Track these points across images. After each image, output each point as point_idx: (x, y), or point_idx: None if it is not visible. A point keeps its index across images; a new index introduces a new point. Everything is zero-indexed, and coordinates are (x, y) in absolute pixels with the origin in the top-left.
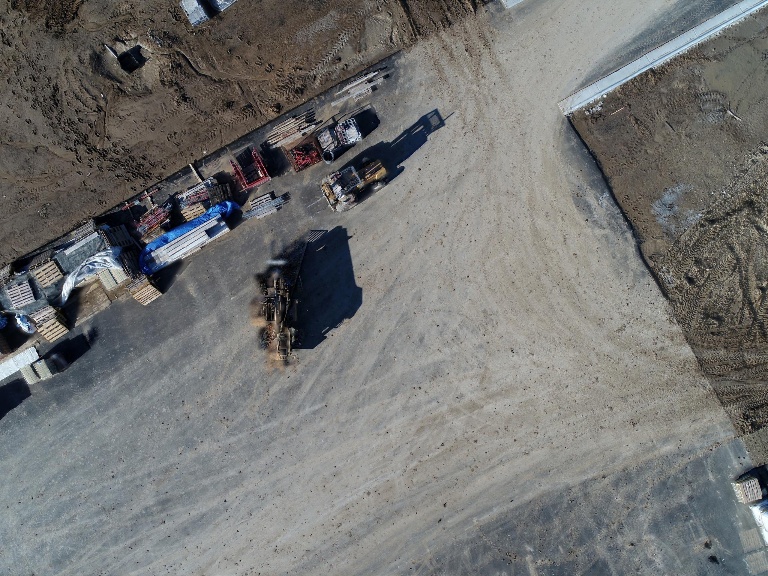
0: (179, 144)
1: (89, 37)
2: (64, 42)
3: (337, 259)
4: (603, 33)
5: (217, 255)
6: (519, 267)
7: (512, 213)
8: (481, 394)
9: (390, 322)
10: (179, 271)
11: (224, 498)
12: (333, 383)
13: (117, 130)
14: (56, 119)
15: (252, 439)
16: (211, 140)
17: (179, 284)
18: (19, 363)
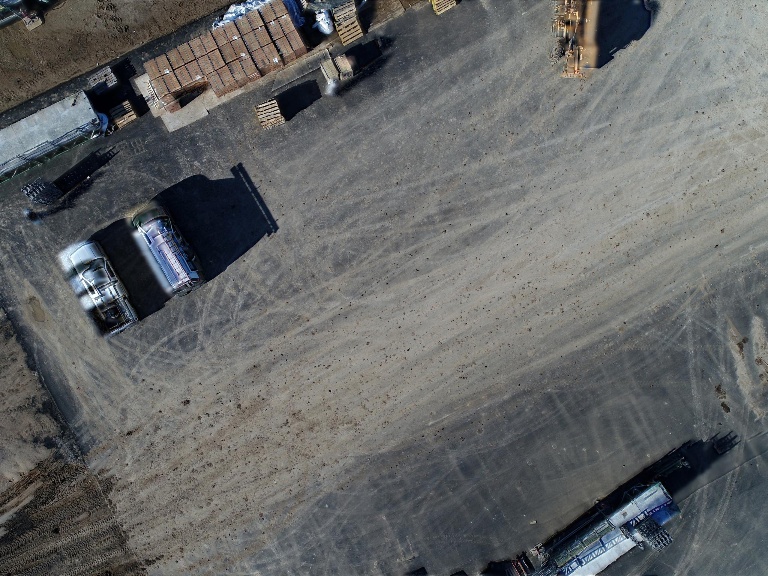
0: None
1: None
2: None
3: None
4: None
5: None
6: None
7: None
8: (763, 122)
9: (677, 46)
10: None
11: (505, 211)
12: (618, 103)
13: None
14: None
15: (536, 154)
16: None
17: None
18: (311, 65)
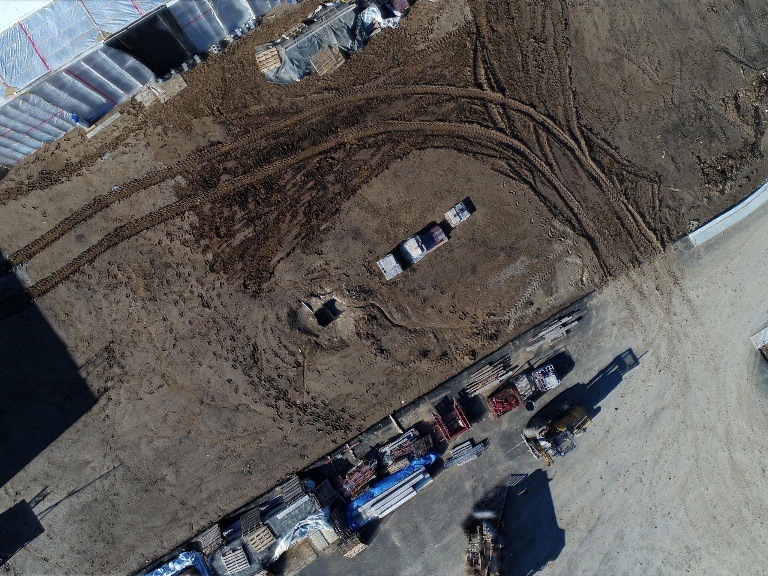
0: (377, 395)
1: (286, 295)
2: (262, 302)
3: (538, 502)
4: None
5: (420, 504)
6: (719, 501)
7: (710, 448)
8: None
9: (594, 562)
10: (383, 521)
11: None
12: None
13: (316, 384)
14: (256, 377)
15: None
16: (409, 390)
17: (383, 534)
18: None
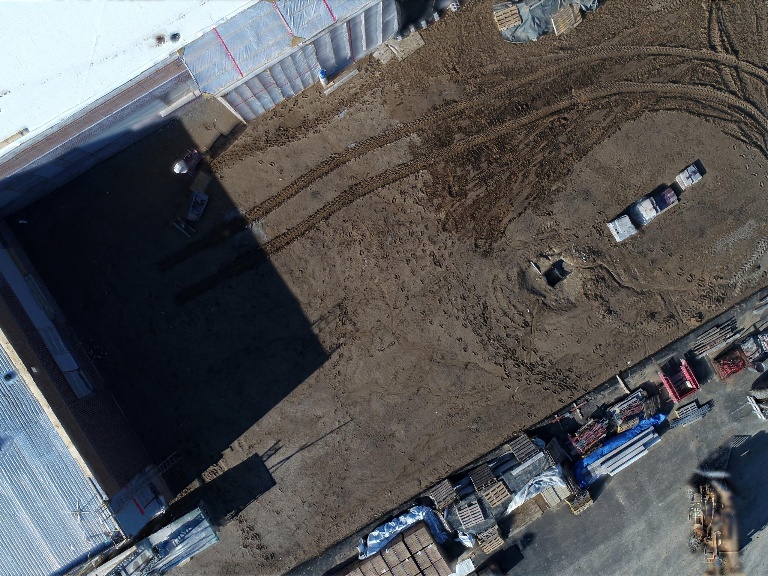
0: (604, 355)
1: (516, 255)
2: (493, 261)
3: (761, 463)
4: None
5: (644, 463)
6: None
7: None
8: None
9: None
10: (608, 480)
11: None
12: None
13: (544, 344)
14: (486, 336)
15: None
16: (635, 350)
17: (608, 492)
18: (456, 574)
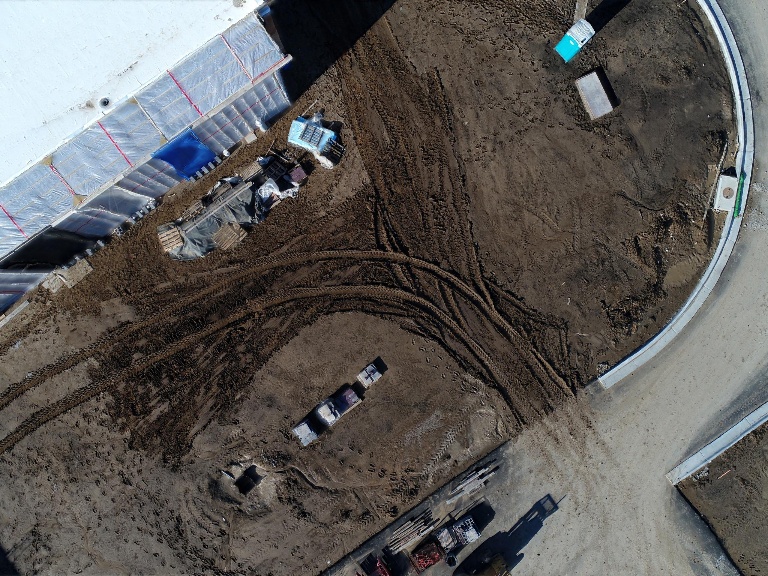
0: (303, 557)
1: (206, 466)
2: (183, 475)
3: None
4: (702, 401)
5: None
6: None
7: None
8: None
9: None
10: None
11: None
12: None
13: (242, 551)
14: (182, 549)
15: None
16: (334, 550)
17: None
18: None
